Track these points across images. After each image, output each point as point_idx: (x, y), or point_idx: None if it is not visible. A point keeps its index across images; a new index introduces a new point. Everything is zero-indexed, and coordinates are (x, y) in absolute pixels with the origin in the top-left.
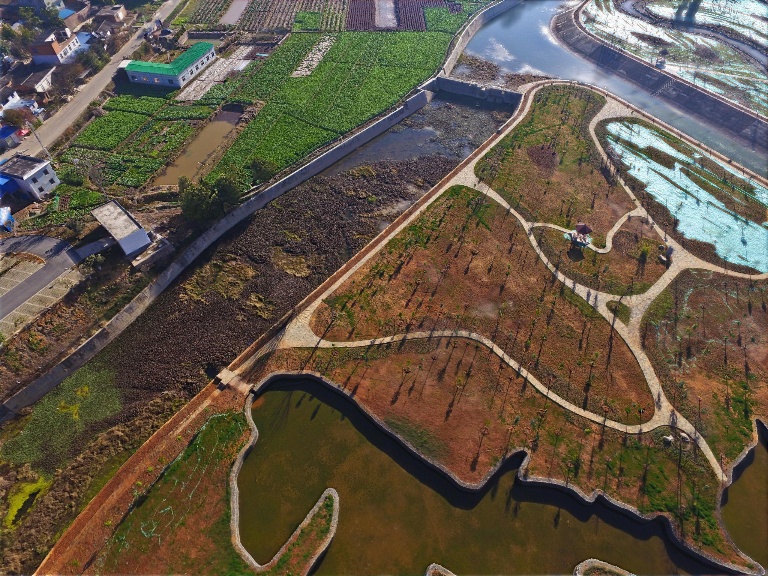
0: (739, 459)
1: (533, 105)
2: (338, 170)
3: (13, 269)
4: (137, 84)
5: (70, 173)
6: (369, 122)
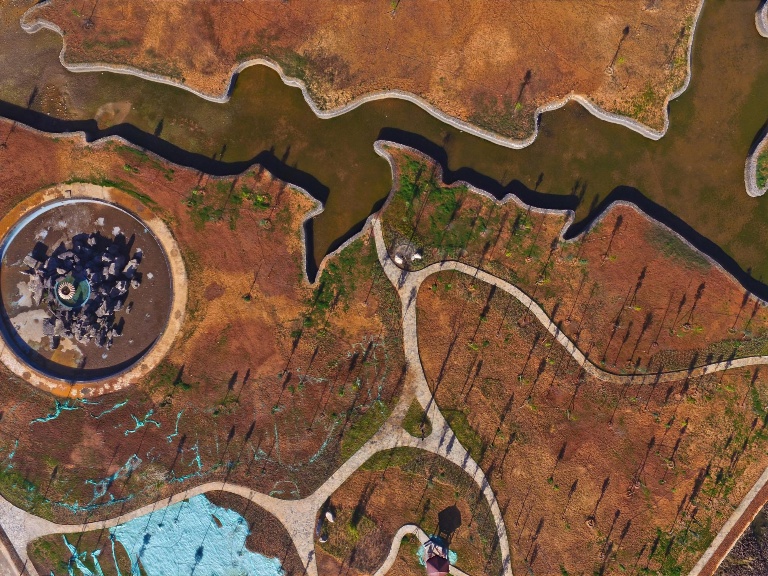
0: (351, 240)
1: None
2: None
3: None
4: None
5: None
6: None
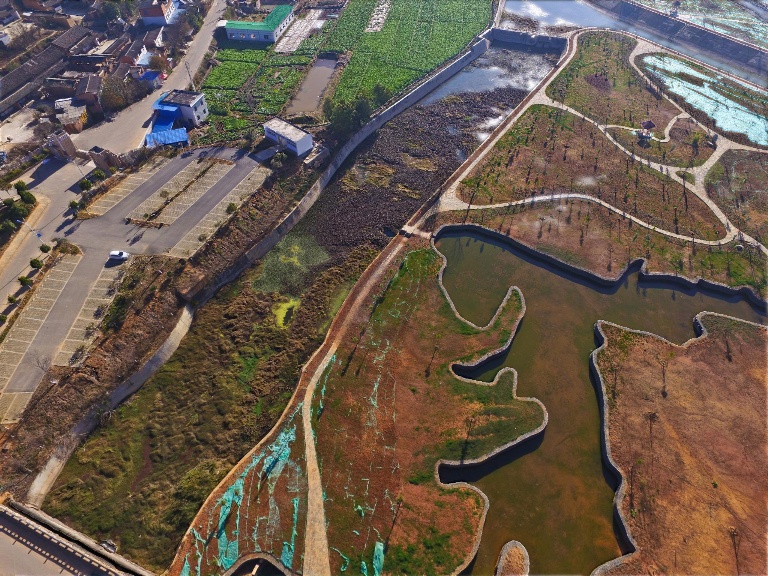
0: None
1: (579, 46)
2: (431, 100)
3: (211, 169)
4: (235, 41)
5: (214, 106)
6: (446, 64)
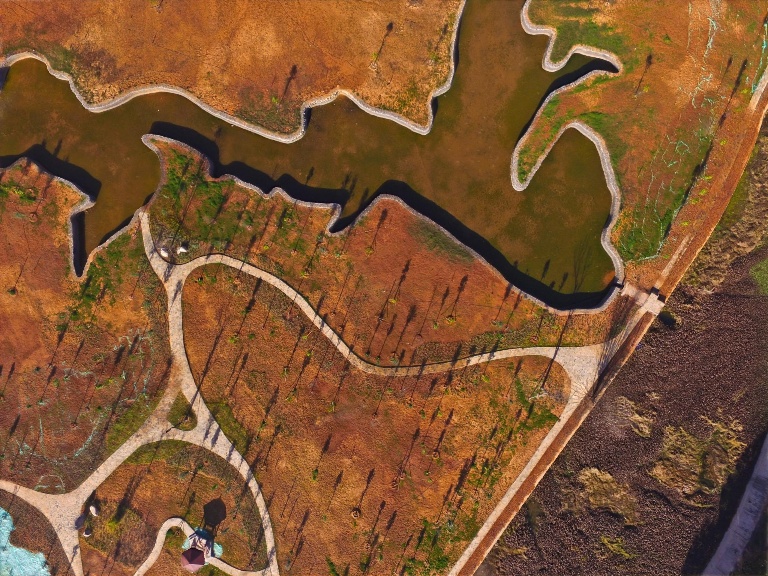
0: (119, 234)
1: None
2: None
3: None
4: None
5: None
6: None
